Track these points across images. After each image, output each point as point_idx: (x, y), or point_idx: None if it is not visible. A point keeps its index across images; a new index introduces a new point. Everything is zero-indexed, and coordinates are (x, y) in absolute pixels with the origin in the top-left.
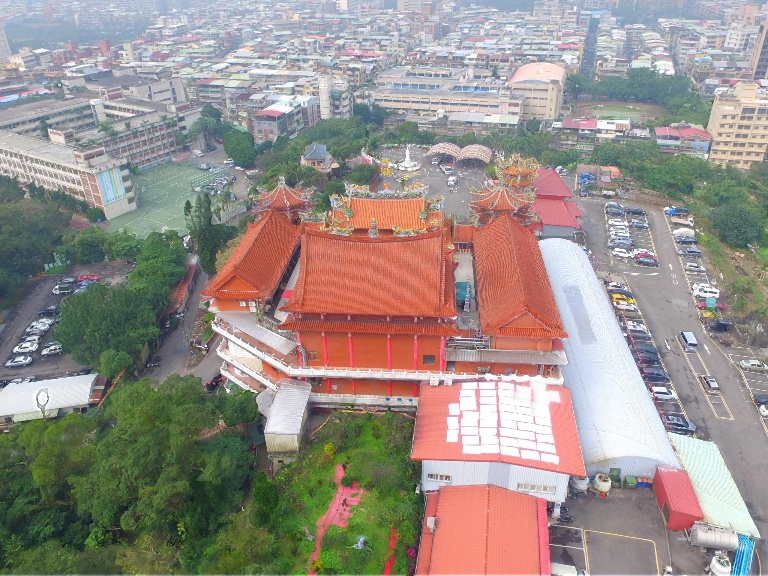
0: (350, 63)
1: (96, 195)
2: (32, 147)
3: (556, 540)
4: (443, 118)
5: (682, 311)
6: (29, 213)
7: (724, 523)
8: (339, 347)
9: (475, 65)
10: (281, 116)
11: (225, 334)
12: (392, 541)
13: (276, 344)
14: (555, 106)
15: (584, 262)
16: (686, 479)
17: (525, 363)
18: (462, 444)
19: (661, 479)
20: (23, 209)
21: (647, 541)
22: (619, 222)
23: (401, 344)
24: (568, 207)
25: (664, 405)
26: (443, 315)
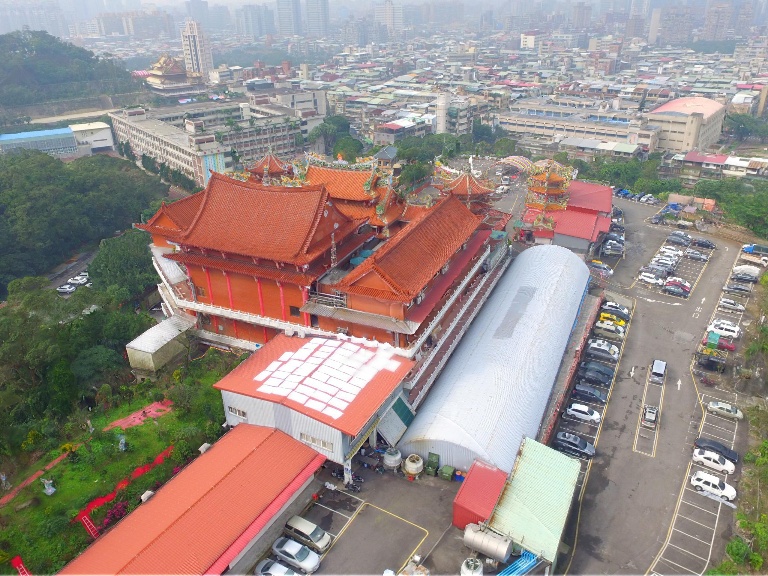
0: None
1: (201, 176)
2: (170, 133)
3: (330, 503)
4: None
5: (679, 343)
6: (133, 180)
7: (516, 534)
8: (220, 286)
9: (630, 99)
10: (400, 130)
11: (157, 268)
12: (162, 454)
13: (173, 276)
14: (694, 141)
15: (570, 271)
16: (500, 480)
17: (371, 326)
18: (263, 383)
19: None
20: (129, 176)
21: (421, 529)
22: (672, 250)
23: (269, 290)
24: (599, 222)
25: (579, 425)
26: (296, 262)
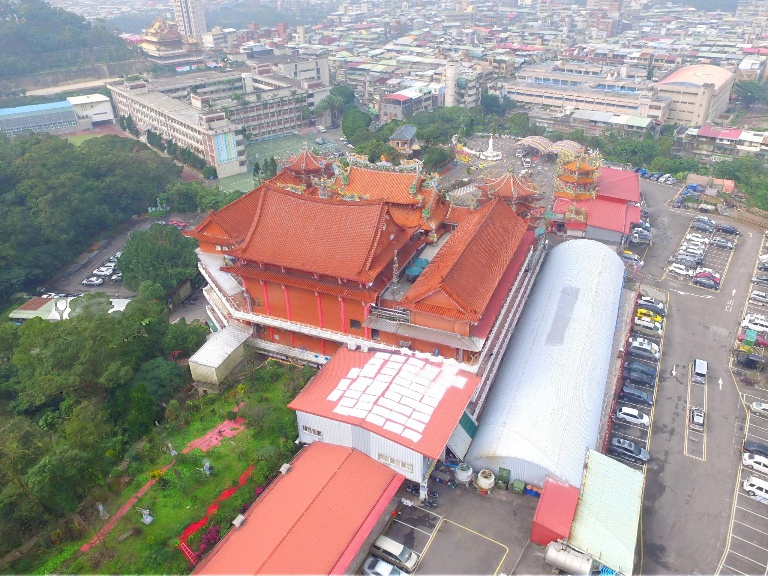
0: (503, 56)
1: (212, 155)
2: (176, 109)
3: (409, 520)
4: (569, 115)
5: (716, 339)
6: (146, 162)
7: (594, 551)
8: (278, 298)
9: (636, 65)
10: (407, 101)
11: (204, 274)
12: (244, 475)
13: (227, 286)
14: (704, 112)
15: (608, 268)
16: (573, 496)
17: (437, 342)
18: (338, 404)
19: (542, 489)
20: (142, 158)
21: (501, 546)
22: (698, 238)
23: (330, 304)
24: (629, 212)
25: (629, 428)
26: (361, 280)
